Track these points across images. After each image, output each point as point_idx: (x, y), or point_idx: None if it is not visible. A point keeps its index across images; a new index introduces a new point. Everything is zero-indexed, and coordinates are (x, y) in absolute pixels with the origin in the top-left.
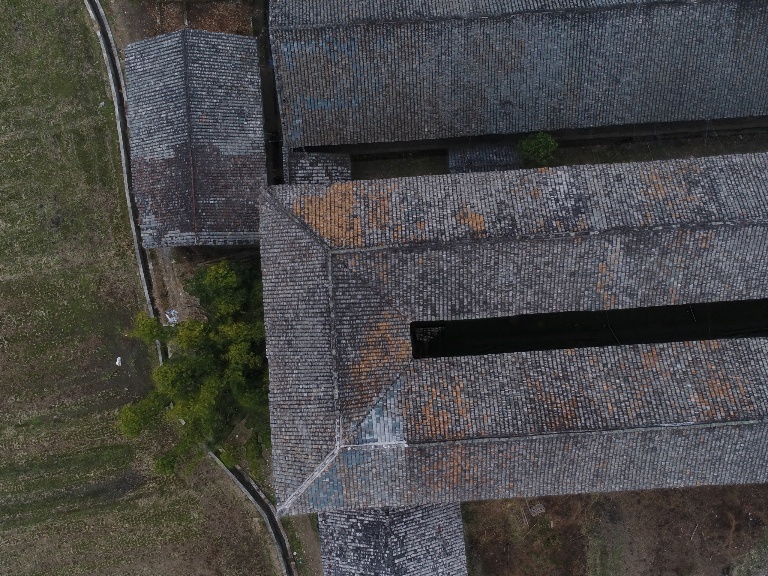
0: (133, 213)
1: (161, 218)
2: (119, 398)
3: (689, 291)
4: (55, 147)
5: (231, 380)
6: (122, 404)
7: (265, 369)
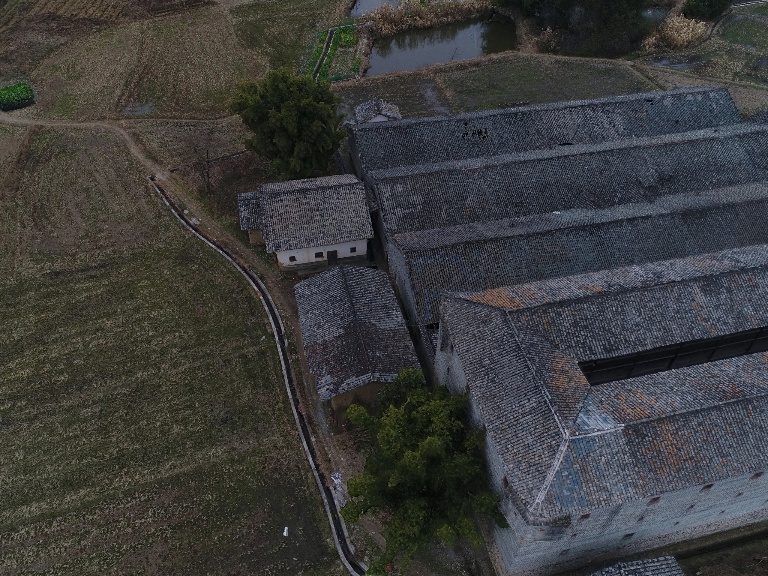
0: (294, 402)
1: (336, 374)
2: (289, 569)
3: (762, 317)
4: (226, 368)
5: (439, 445)
6: (292, 575)
7: (464, 438)
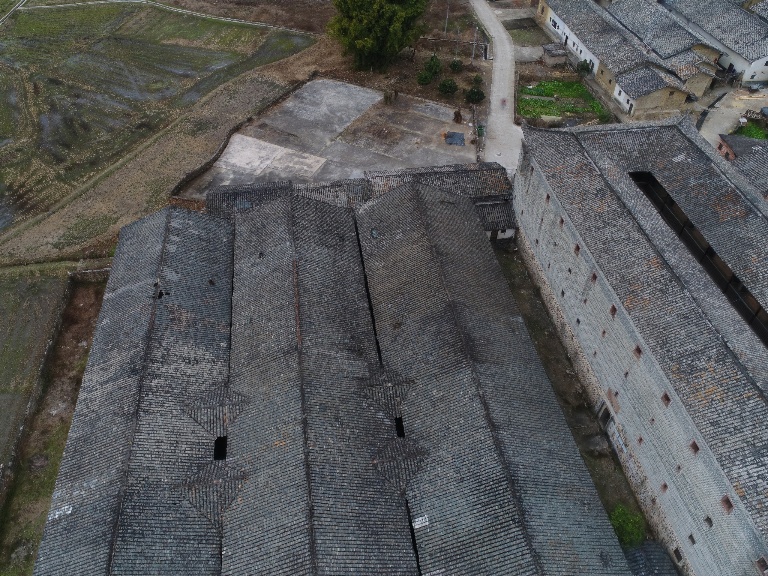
0: None
1: None
2: None
3: None
4: None
5: None
6: None
7: None
